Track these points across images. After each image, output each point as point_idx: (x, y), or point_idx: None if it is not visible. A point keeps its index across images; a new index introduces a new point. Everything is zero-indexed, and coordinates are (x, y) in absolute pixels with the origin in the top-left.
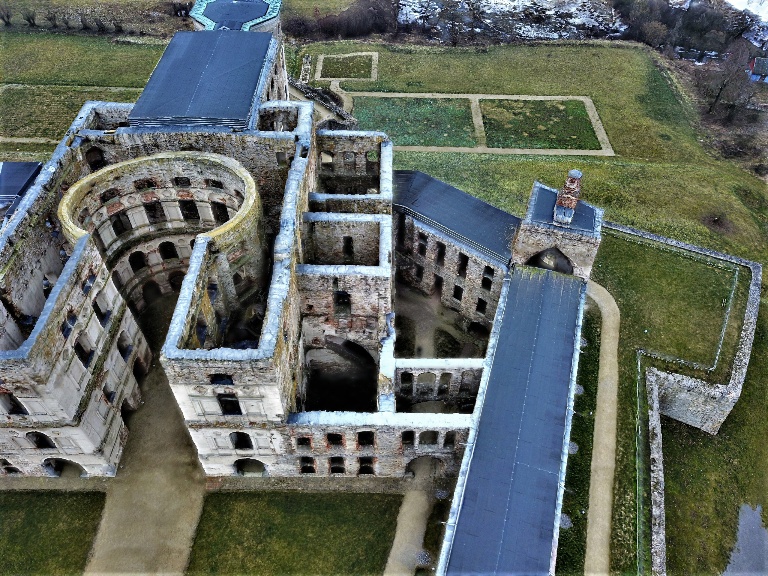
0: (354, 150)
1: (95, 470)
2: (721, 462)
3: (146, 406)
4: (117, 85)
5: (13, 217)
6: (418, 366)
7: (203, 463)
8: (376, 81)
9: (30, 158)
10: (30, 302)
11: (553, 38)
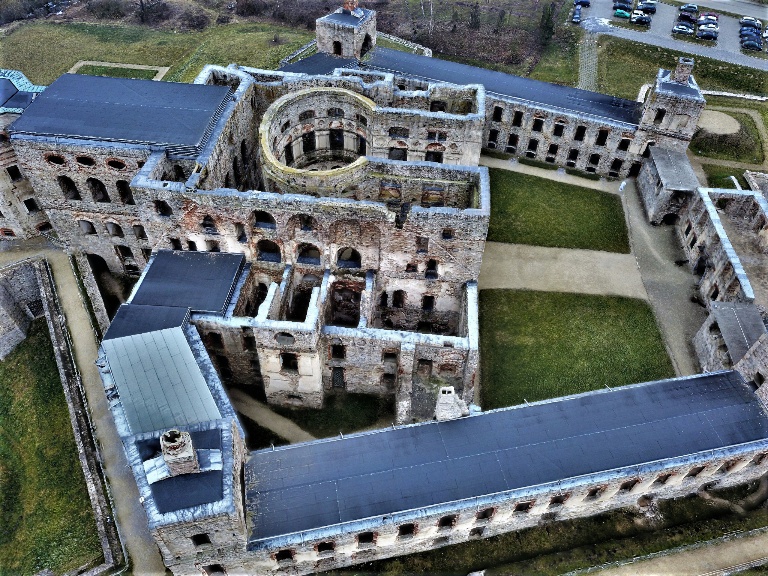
0: None
1: None
2: None
3: None
4: None
5: (329, 201)
6: None
7: None
8: None
9: None
10: None
11: None
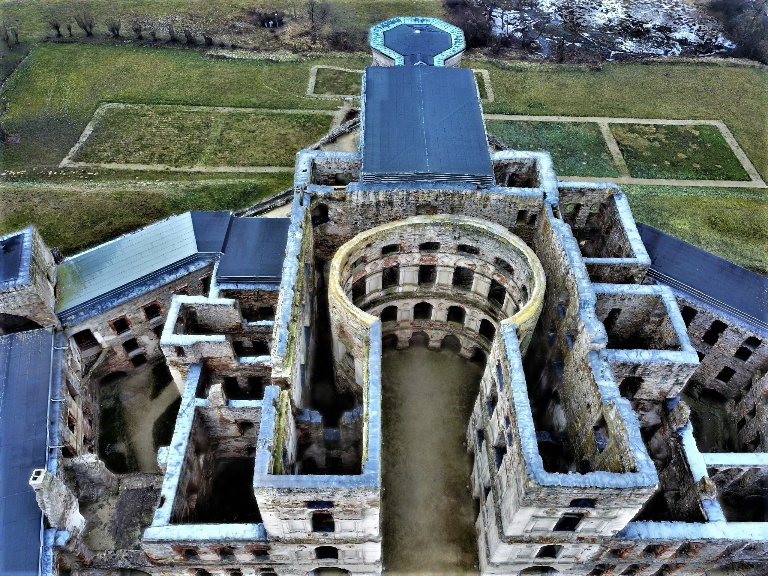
0: (581, 202)
1: (363, 575)
2: None
3: (389, 493)
4: (224, 105)
5: (283, 297)
6: (729, 462)
7: (489, 570)
8: (495, 102)
9: (161, 190)
10: (297, 391)
11: (658, 54)
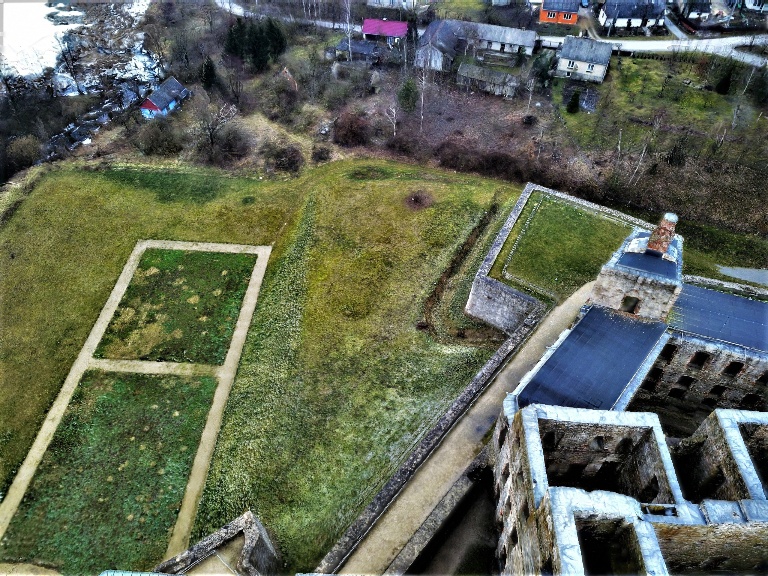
0: None
1: None
2: (692, 273)
3: None
4: None
5: None
6: None
7: None
8: None
9: None
10: None
11: None
